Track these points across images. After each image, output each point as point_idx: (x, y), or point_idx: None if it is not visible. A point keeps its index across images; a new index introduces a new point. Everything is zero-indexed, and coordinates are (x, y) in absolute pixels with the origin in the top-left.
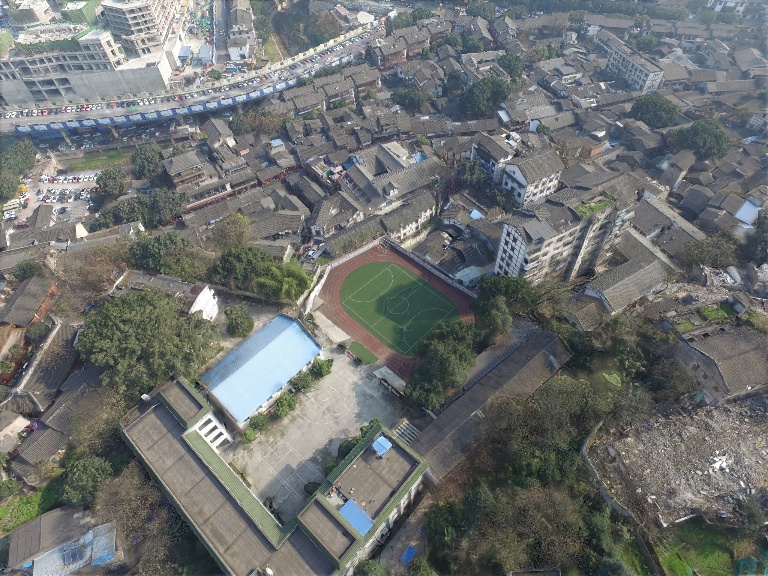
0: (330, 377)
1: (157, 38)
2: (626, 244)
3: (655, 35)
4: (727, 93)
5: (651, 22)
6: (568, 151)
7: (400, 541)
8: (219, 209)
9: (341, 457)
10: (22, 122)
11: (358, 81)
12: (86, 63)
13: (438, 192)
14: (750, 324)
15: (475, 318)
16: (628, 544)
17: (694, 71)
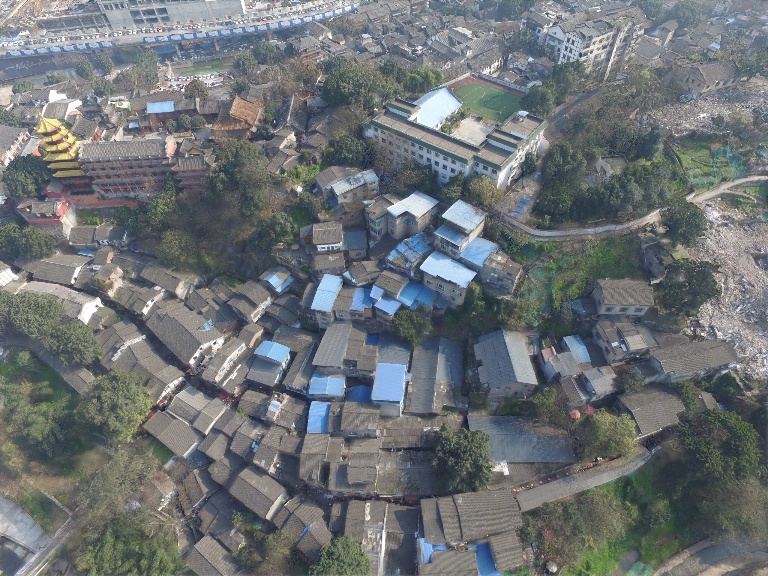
0: (464, 126)
1: None
2: (637, 62)
3: None
4: None
5: None
6: None
7: (531, 175)
8: None
9: None
10: None
11: (412, 1)
12: None
13: None
14: (716, 60)
15: None
16: None
17: None
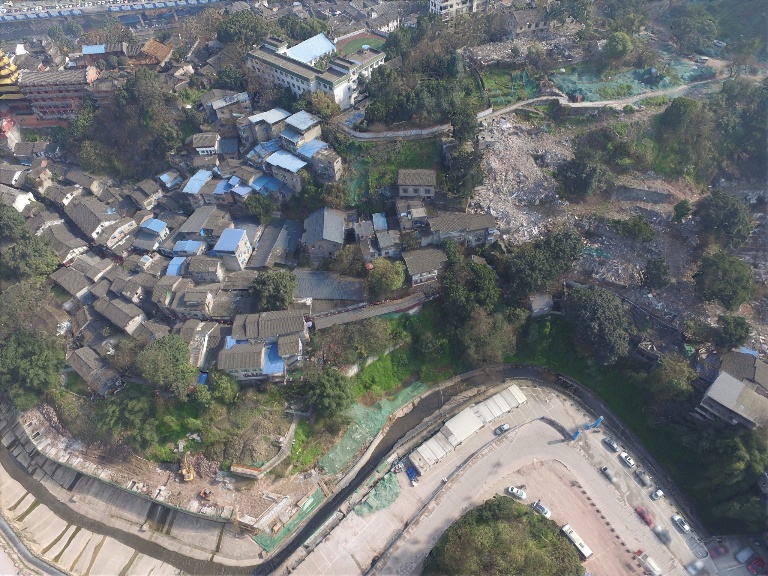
0: None
1: None
2: None
3: None
4: None
5: None
6: None
7: None
8: None
9: None
10: None
11: None
12: None
13: (402, 16)
14: None
15: None
16: (470, 76)
17: None
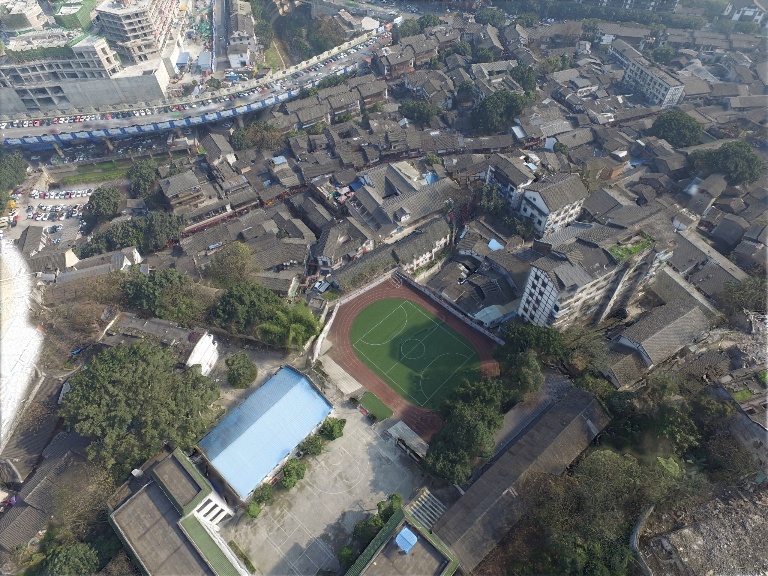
0: (341, 436)
1: (154, 45)
2: (659, 283)
3: (672, 45)
4: (751, 109)
5: (668, 32)
6: (589, 173)
7: None
8: (219, 233)
9: (357, 541)
10: (12, 134)
11: (364, 92)
12: (80, 71)
13: (452, 218)
14: None
15: (501, 371)
16: None
17: (715, 85)
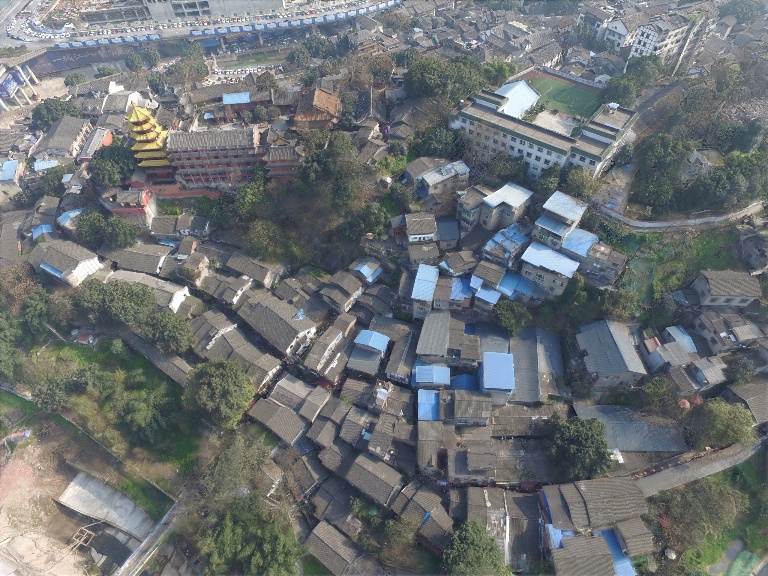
0: (541, 119)
1: None
2: (705, 56)
3: None
4: None
5: None
6: None
7: (619, 167)
8: None
9: None
10: None
11: None
12: None
13: None
14: None
15: None
16: None
17: None
